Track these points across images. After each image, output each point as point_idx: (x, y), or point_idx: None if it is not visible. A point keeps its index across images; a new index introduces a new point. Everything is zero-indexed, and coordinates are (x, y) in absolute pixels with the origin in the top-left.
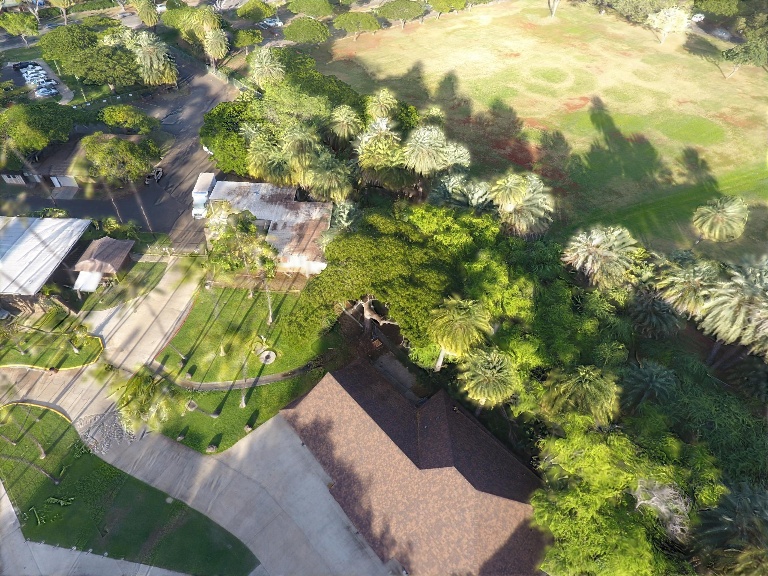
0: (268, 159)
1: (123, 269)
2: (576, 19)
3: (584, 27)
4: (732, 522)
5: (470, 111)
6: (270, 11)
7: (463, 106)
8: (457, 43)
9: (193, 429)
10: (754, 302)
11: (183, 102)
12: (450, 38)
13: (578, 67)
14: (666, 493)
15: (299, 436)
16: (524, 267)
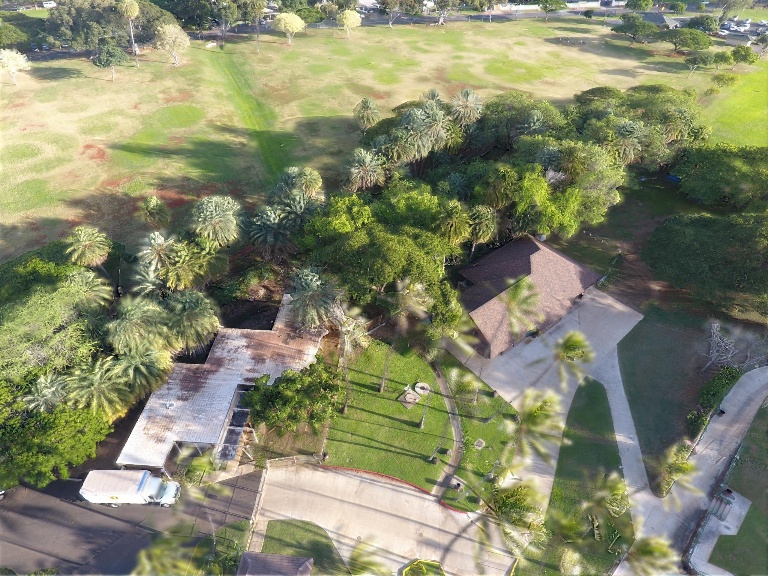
0: (125, 377)
1: None
2: None
3: None
4: None
5: (55, 217)
6: None
7: (38, 221)
8: None
9: (502, 437)
10: (425, 129)
11: None
12: None
13: (18, 135)
14: (551, 174)
15: (509, 345)
16: None
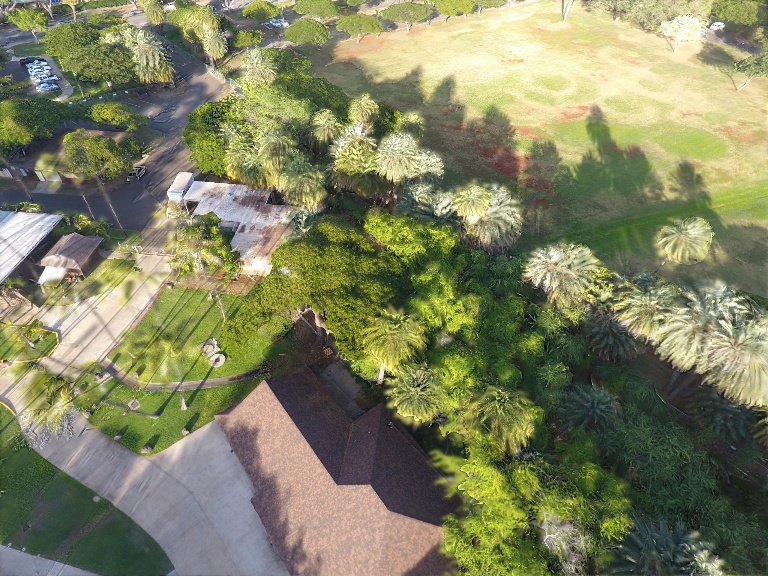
0: (244, 161)
1: (90, 265)
2: (588, 25)
3: (595, 34)
4: (637, 564)
5: (463, 117)
6: (275, 12)
7: (456, 112)
8: (461, 47)
9: (132, 429)
10: (707, 330)
11: (178, 100)
12: (455, 42)
13: (582, 75)
14: (566, 529)
15: (229, 443)
16: (484, 281)
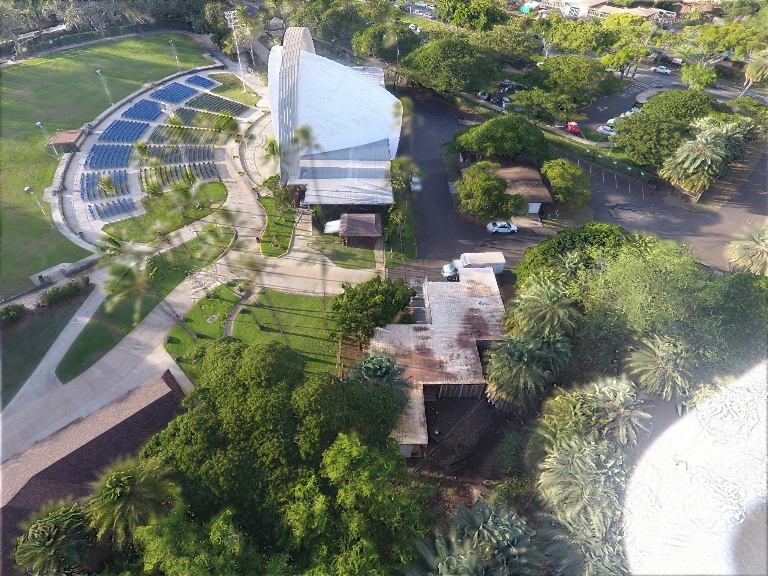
0: (526, 293)
1: (359, 243)
2: None
3: None
4: None
5: None
6: None
7: None
8: None
9: (190, 325)
10: None
11: (670, 213)
12: None
13: None
14: None
15: None
16: None
